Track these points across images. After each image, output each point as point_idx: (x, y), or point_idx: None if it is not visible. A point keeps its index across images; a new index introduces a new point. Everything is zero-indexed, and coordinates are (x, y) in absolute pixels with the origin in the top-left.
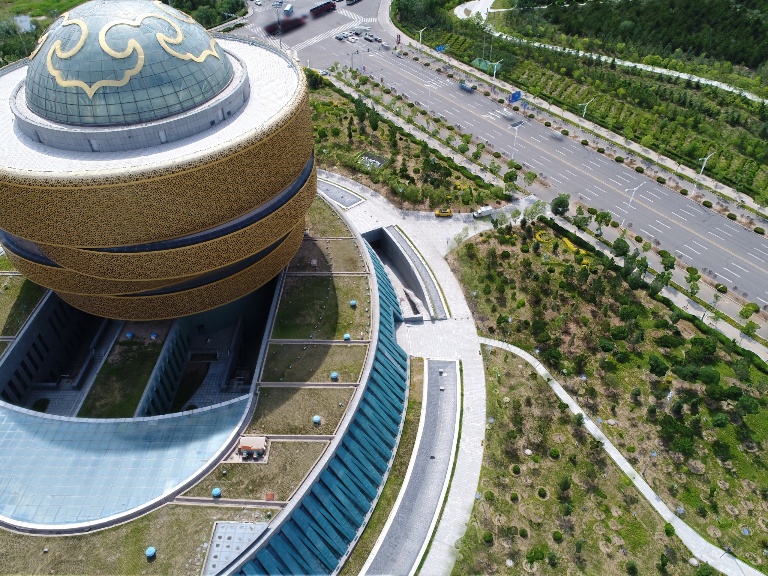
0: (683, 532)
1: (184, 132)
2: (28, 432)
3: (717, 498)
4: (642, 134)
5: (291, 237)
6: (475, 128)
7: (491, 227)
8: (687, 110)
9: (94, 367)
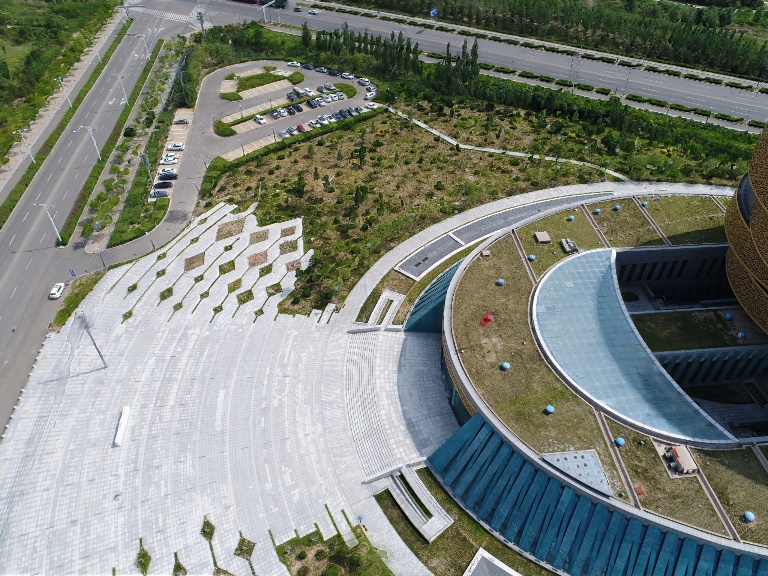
0: None
1: None
2: (601, 291)
3: None
4: None
5: None
6: None
7: None
8: None
9: None
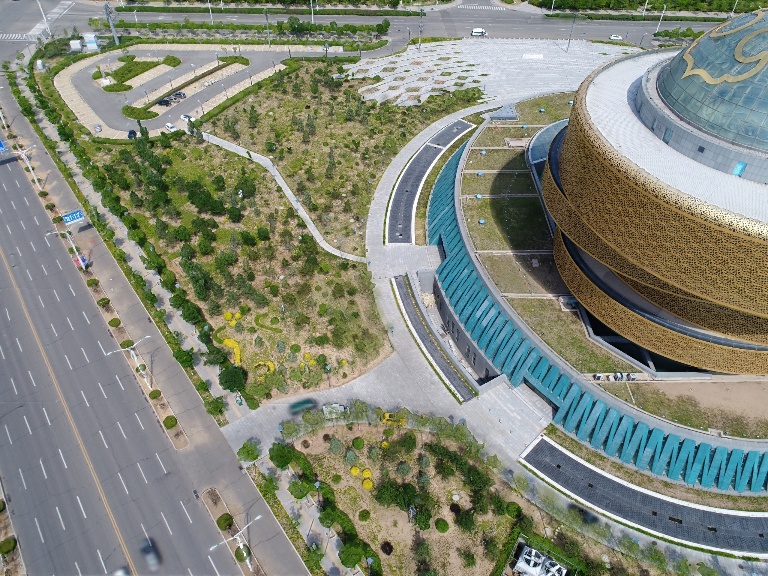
0: (269, 165)
1: None
2: None
3: None
4: None
5: None
6: None
7: (329, 392)
8: None
9: None
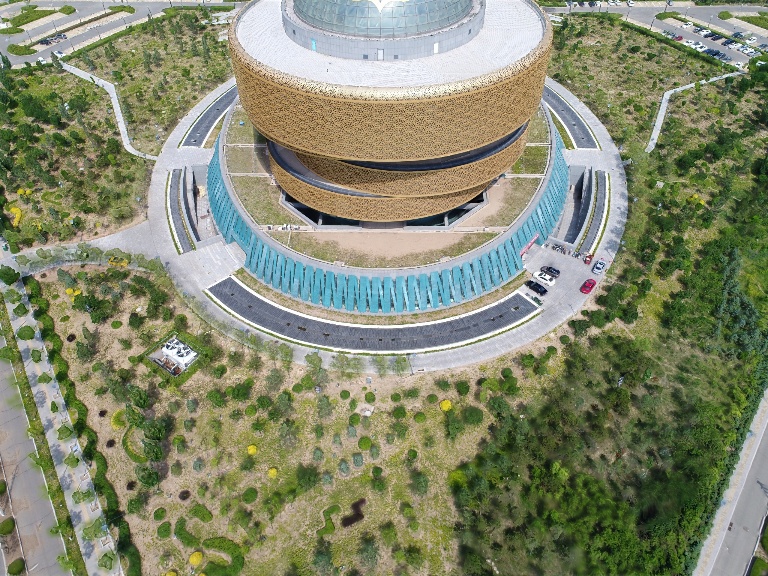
0: None
1: None
2: None
3: None
4: None
5: None
6: None
7: None
8: None
9: None
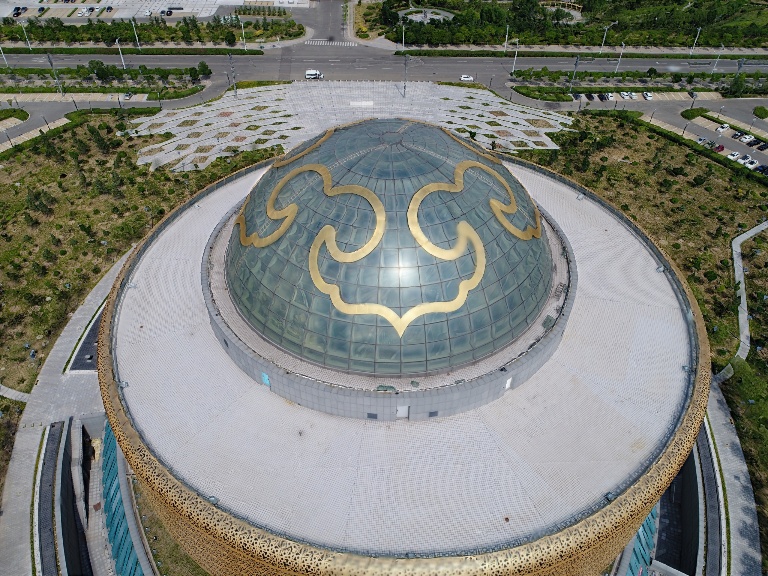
0: None
1: None
2: None
3: None
4: None
5: None
6: None
7: None
8: None
9: None
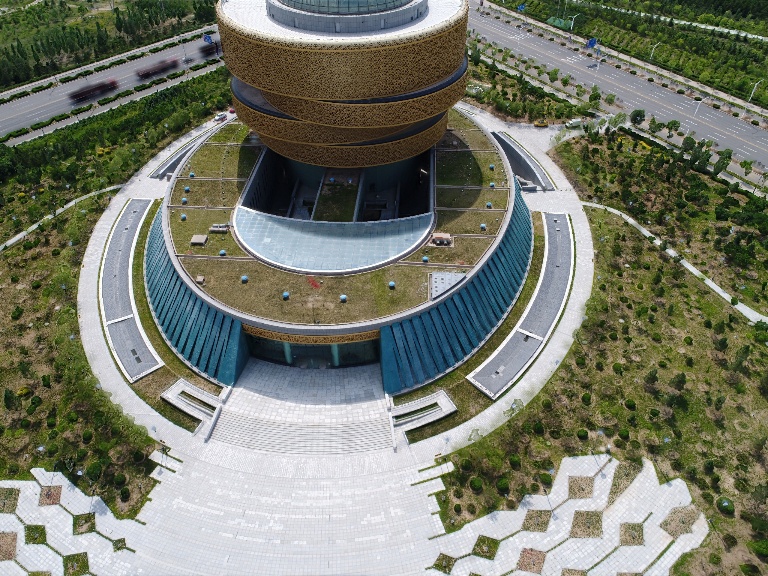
0: (743, 309)
1: (395, 22)
2: (283, 227)
3: (767, 292)
4: (699, 74)
5: (444, 118)
6: (557, 68)
7: (581, 134)
8: (737, 55)
9: (295, 210)
